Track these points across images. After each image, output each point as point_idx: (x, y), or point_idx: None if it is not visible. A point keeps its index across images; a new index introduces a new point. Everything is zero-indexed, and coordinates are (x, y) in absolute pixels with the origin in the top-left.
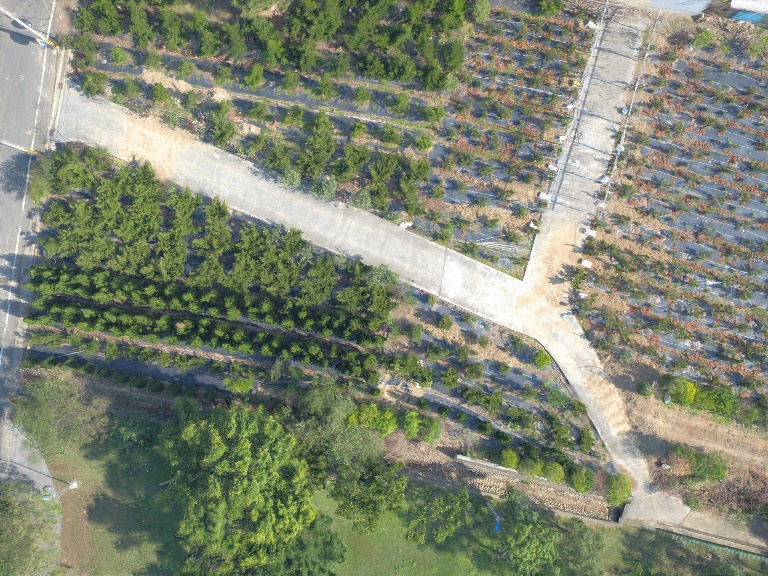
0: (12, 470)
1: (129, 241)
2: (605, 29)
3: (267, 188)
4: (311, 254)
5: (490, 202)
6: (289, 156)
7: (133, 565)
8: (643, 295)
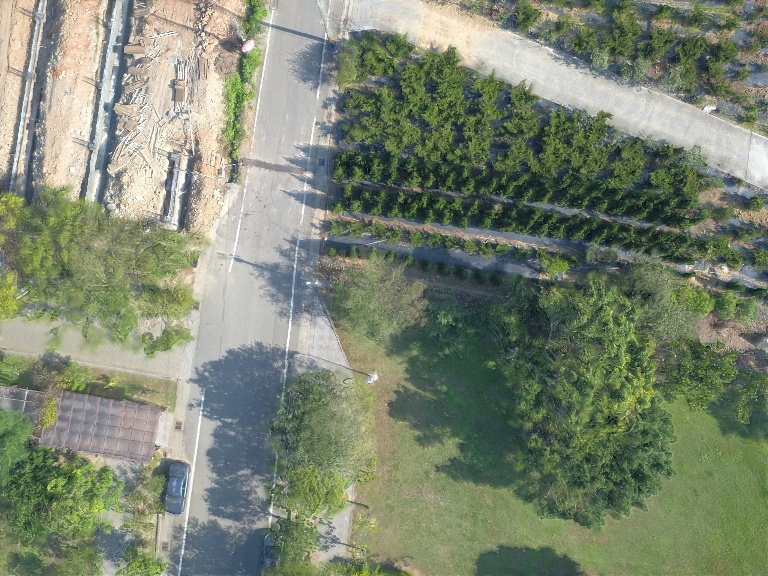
0: (310, 363)
1: (434, 127)
2: None
3: (568, 74)
4: (619, 137)
5: None
6: (593, 40)
7: (436, 458)
8: None
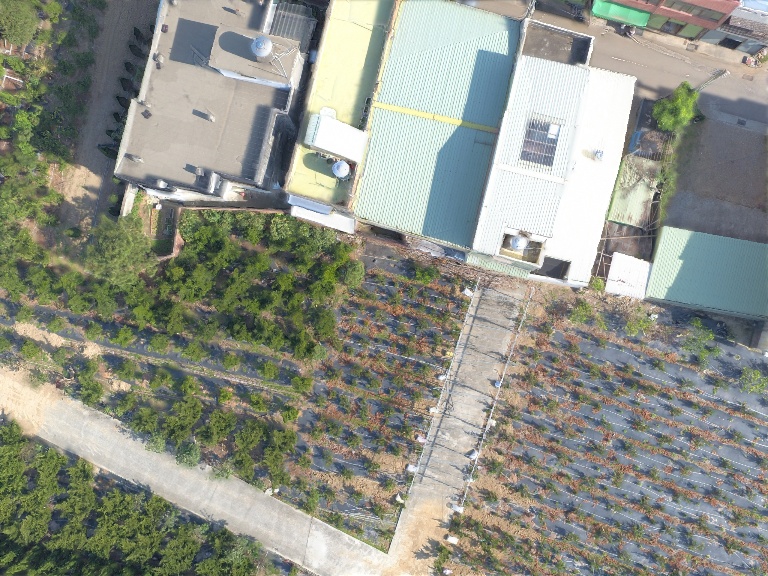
0: None
1: None
2: (482, 297)
3: (134, 448)
4: (173, 521)
5: (357, 472)
6: (155, 420)
7: None
8: (508, 575)
